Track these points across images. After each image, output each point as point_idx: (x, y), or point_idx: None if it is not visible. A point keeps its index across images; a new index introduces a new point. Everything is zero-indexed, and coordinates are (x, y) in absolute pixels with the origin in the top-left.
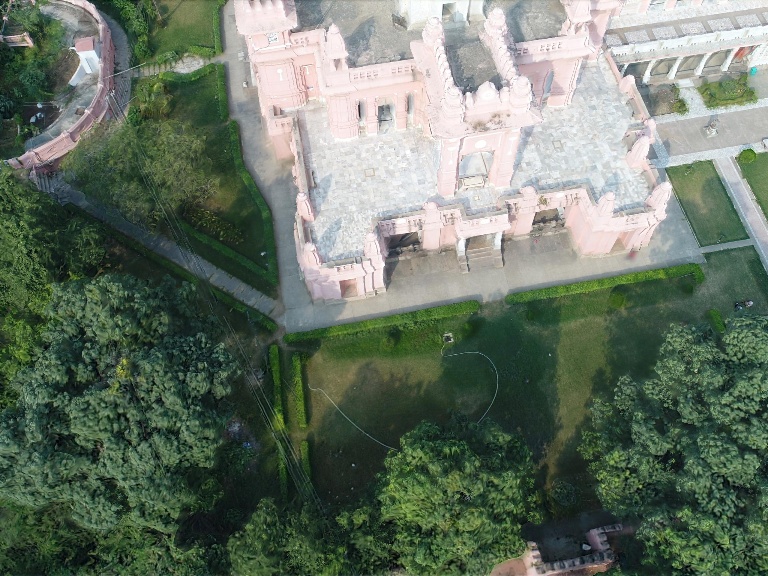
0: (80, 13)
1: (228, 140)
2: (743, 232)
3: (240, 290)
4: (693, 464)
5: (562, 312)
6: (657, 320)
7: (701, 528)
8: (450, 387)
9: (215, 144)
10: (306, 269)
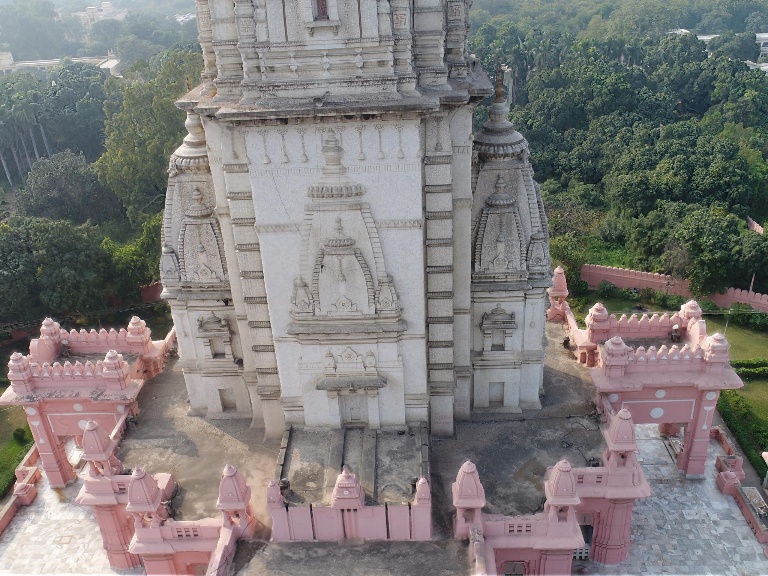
0: None
1: None
2: None
3: None
4: None
5: None
6: None
7: None
8: None
9: None
10: None
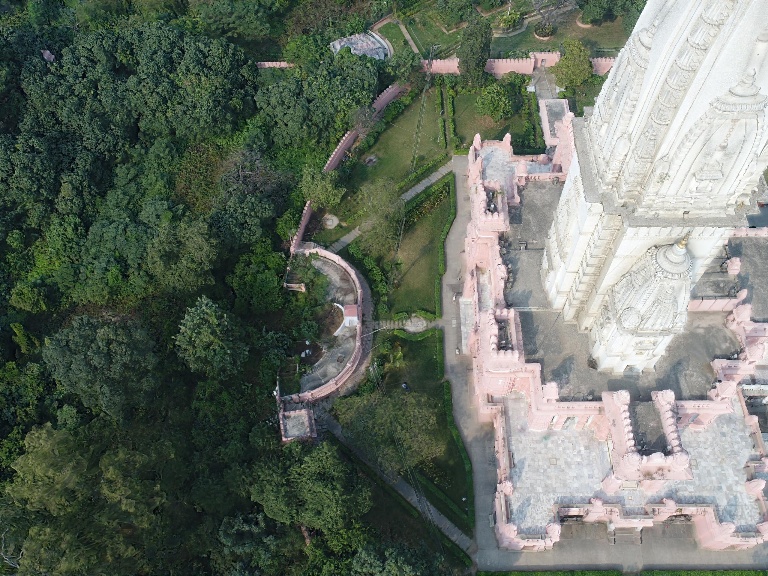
0: (341, 271)
1: (442, 396)
2: None
3: (446, 526)
4: None
5: None
6: None
7: None
8: None
9: None
10: (505, 535)
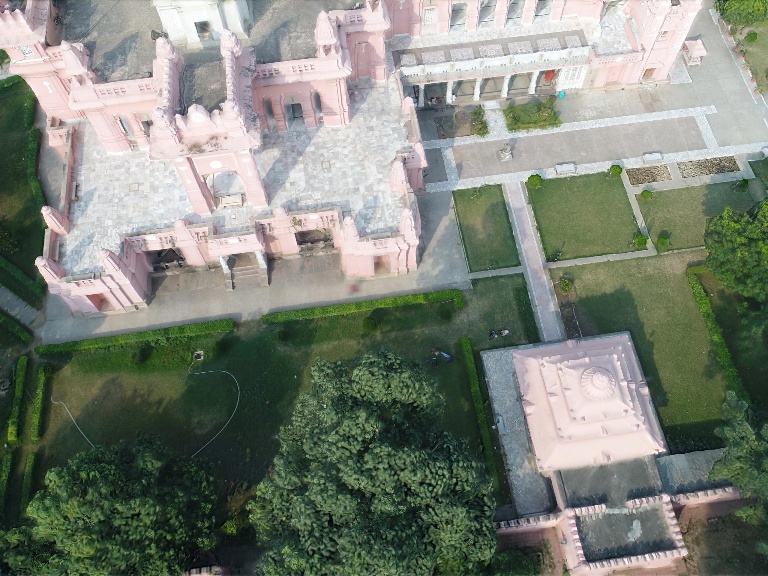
0: None
1: (28, 148)
2: (516, 259)
3: (6, 299)
4: (296, 501)
5: (317, 334)
6: (410, 345)
7: (290, 566)
8: (189, 405)
9: (15, 152)
10: None
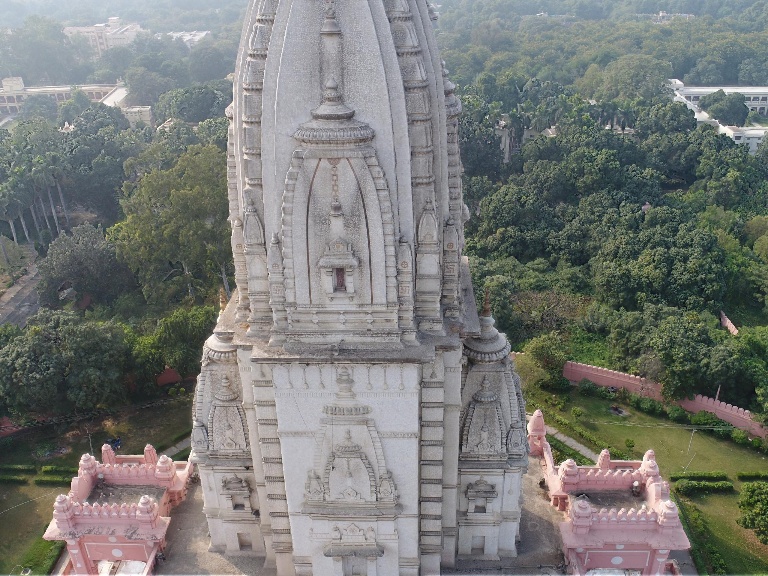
0: None
1: None
2: None
3: None
4: None
5: None
6: None
7: None
8: None
9: None
10: None
